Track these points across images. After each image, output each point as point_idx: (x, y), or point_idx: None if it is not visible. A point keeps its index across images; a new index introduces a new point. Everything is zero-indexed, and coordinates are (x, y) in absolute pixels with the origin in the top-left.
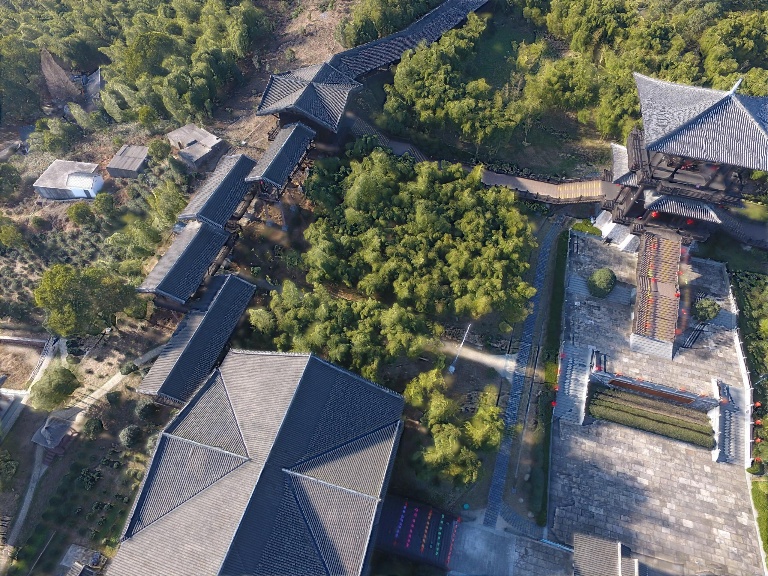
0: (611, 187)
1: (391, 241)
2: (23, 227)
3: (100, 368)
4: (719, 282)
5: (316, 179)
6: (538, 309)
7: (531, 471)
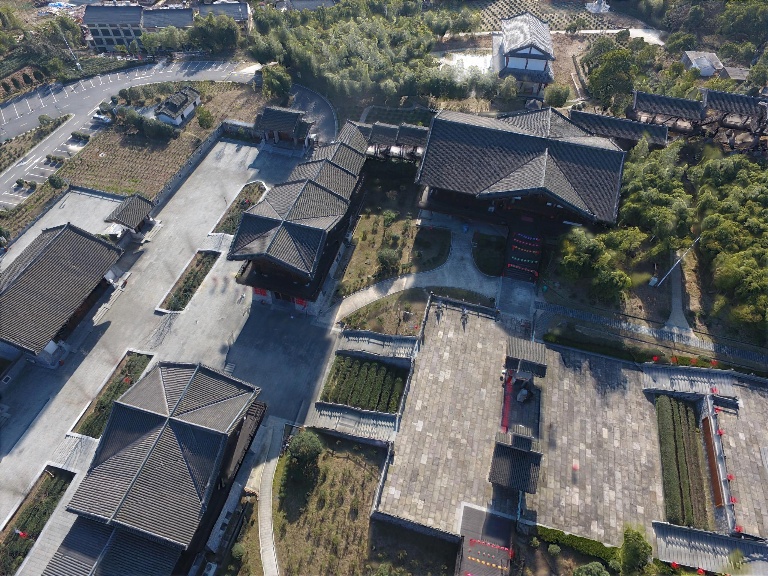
0: None
1: (763, 206)
2: (652, 65)
3: None
4: None
5: None
6: (765, 363)
7: (585, 334)
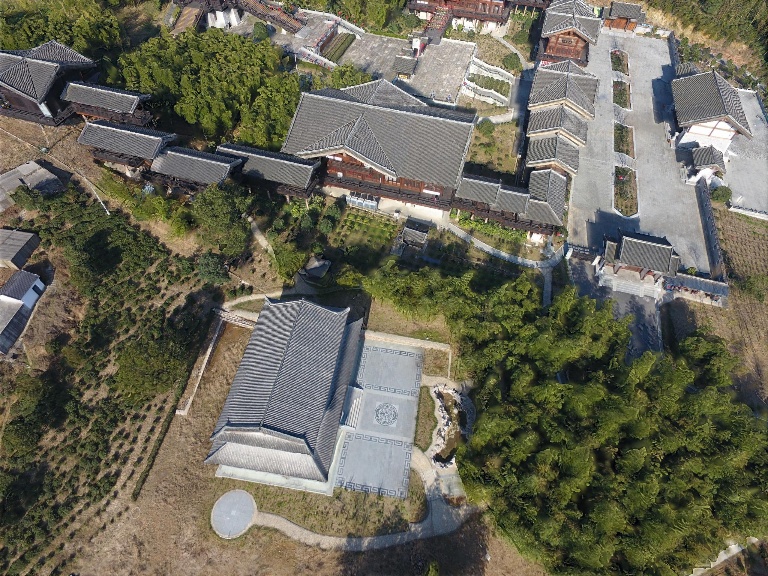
0: (193, 5)
1: None
2: (46, 374)
3: (262, 269)
4: (270, 5)
5: (144, 85)
6: None
7: None
